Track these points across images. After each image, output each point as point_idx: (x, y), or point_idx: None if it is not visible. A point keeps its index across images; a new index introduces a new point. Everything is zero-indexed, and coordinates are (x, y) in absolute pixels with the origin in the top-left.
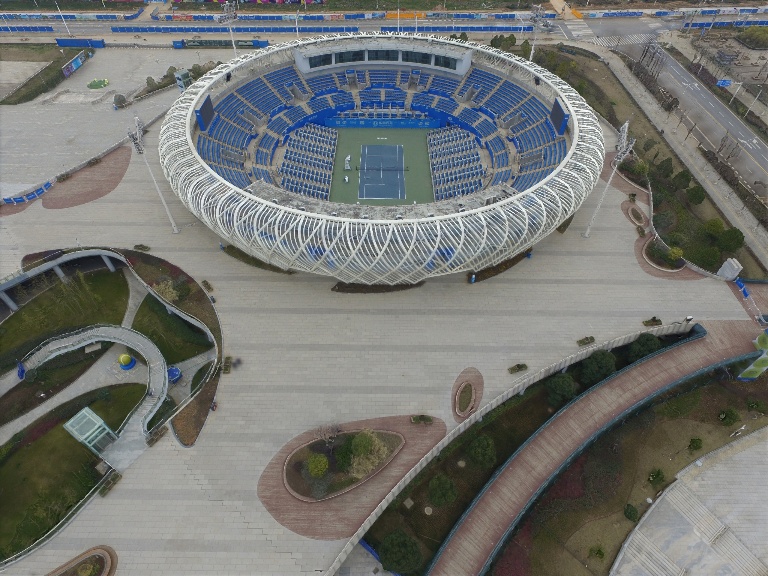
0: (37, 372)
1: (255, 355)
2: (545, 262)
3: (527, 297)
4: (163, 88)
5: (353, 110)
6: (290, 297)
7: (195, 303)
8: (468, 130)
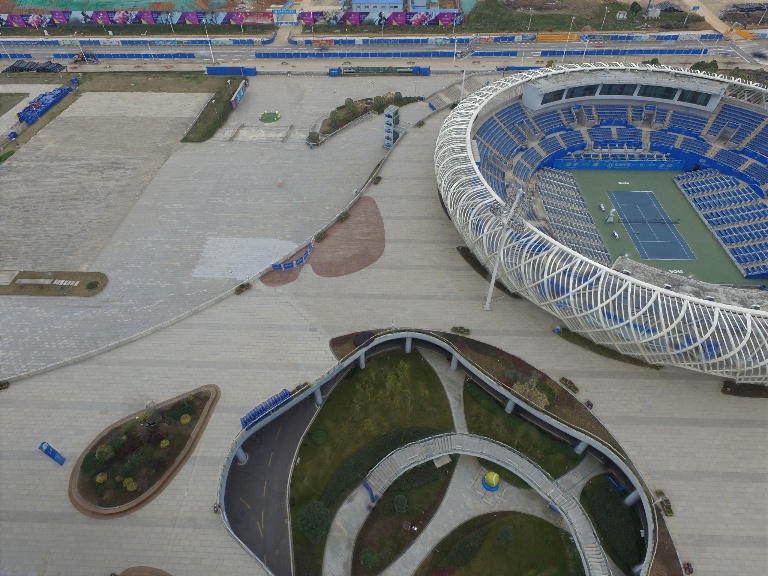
0: (391, 494)
1: (688, 488)
2: None
3: None
4: (350, 123)
5: (583, 150)
6: (678, 402)
7: (568, 409)
8: (731, 175)
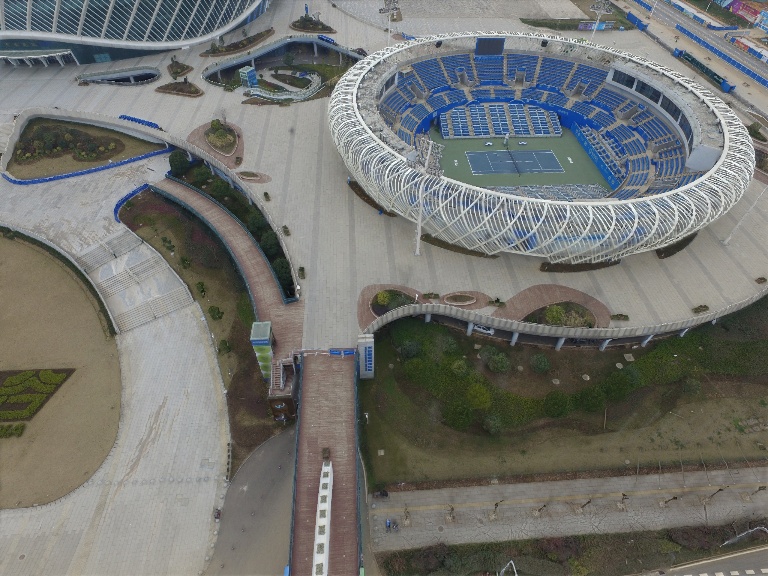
0: None
1: (290, 112)
2: (375, 222)
3: (333, 208)
4: None
5: None
6: None
7: (328, 92)
8: None
